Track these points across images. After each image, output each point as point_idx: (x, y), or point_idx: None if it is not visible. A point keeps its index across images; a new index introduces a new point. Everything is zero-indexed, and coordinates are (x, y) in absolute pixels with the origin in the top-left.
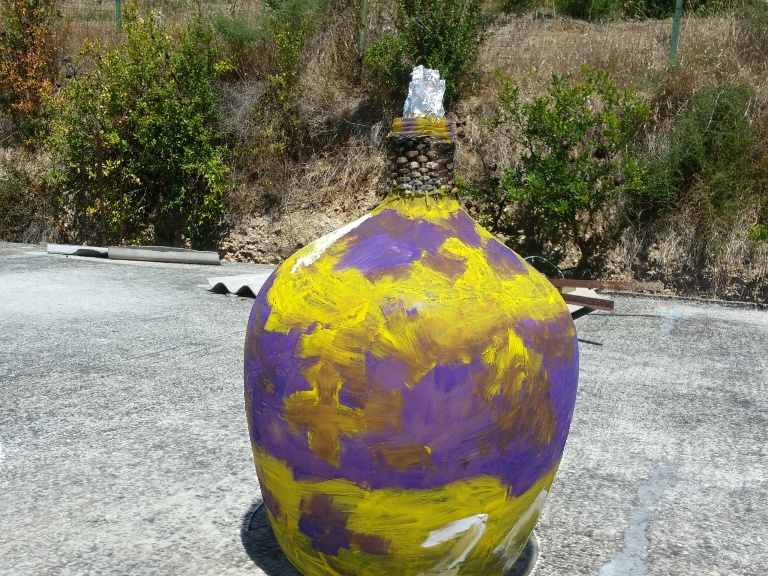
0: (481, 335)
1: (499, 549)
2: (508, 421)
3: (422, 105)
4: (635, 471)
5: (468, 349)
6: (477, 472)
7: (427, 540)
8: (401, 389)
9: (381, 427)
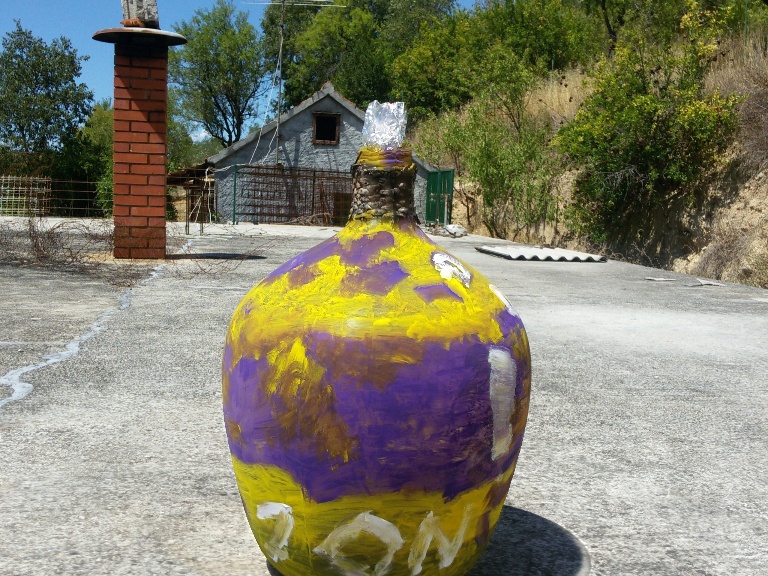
0: (273, 338)
1: (321, 551)
2: (285, 421)
3: (371, 137)
4: None
5: (260, 348)
6: (270, 461)
7: (258, 512)
8: (229, 373)
9: (225, 402)
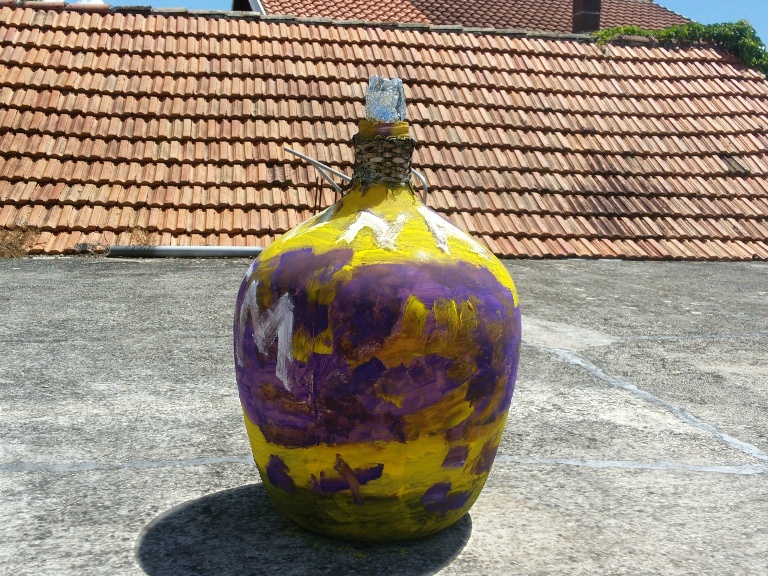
0: None
1: None
2: None
3: None
4: (4, 477)
5: None
6: None
7: None
8: None
9: None
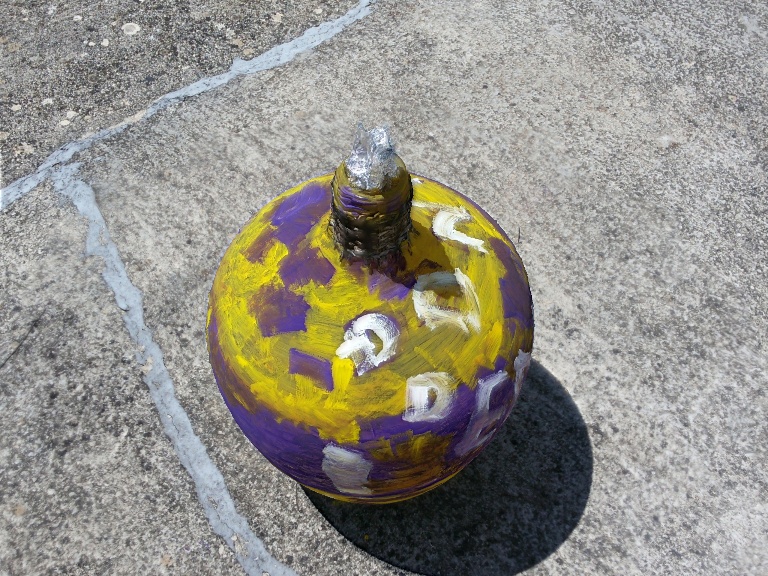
0: None
1: None
2: None
3: None
4: None
5: None
6: None
7: None
8: None
9: None
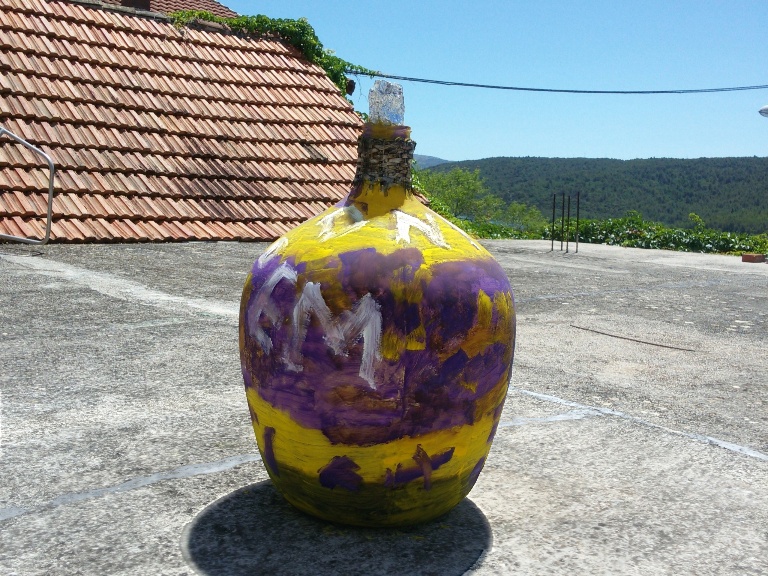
0: None
1: None
2: None
3: None
4: None
5: None
6: None
7: None
8: None
9: None
